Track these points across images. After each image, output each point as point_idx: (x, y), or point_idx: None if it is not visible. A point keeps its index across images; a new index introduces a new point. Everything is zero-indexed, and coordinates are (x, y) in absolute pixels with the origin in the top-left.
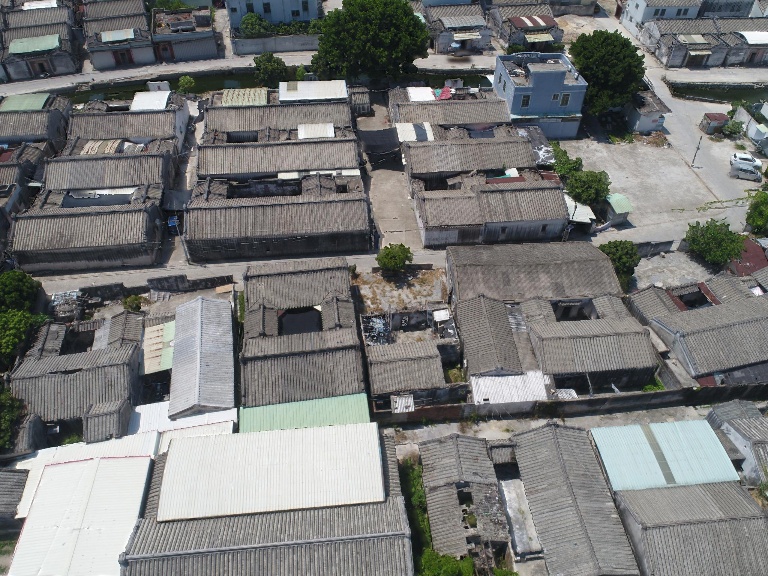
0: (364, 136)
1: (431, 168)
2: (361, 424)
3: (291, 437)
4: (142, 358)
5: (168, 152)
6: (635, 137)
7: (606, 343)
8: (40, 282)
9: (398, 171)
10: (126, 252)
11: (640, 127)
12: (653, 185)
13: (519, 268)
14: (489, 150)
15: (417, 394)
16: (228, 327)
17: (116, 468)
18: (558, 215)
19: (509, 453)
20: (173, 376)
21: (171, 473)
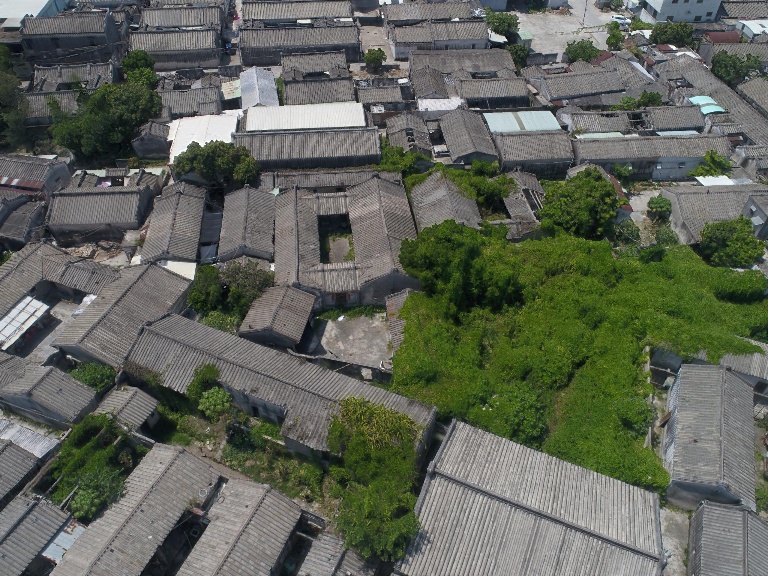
0: (355, 2)
1: (401, 17)
2: (353, 103)
3: (314, 106)
4: (222, 94)
5: (222, 8)
6: (548, 10)
7: (499, 84)
8: (154, 61)
9: (379, 27)
10: (202, 56)
11: (551, 4)
12: (554, 33)
13: (452, 56)
14: (440, 7)
15: (386, 107)
16: (272, 81)
17: (220, 118)
18: (482, 37)
19: (436, 124)
20: (243, 98)
21: (251, 115)
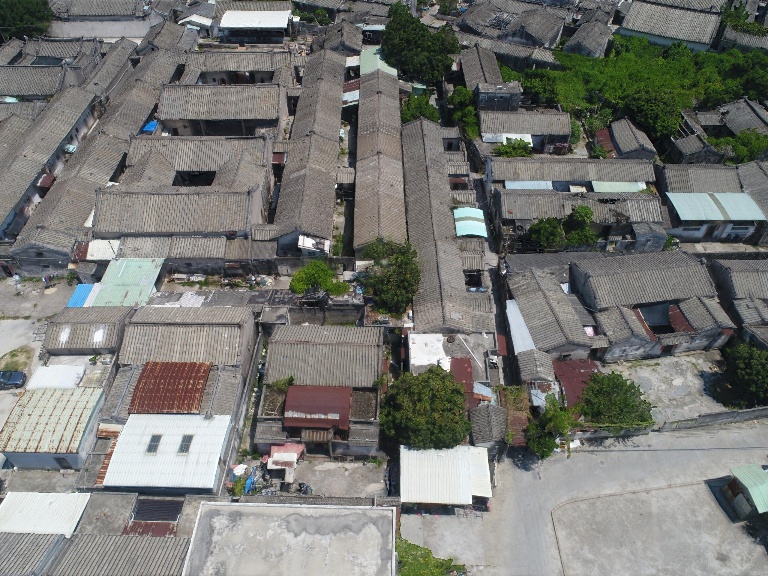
0: None
1: None
2: None
3: None
4: None
5: None
6: None
7: (765, 268)
8: None
9: None
10: None
11: None
12: None
13: None
14: None
15: None
16: None
17: None
18: None
19: None
20: None
21: None
